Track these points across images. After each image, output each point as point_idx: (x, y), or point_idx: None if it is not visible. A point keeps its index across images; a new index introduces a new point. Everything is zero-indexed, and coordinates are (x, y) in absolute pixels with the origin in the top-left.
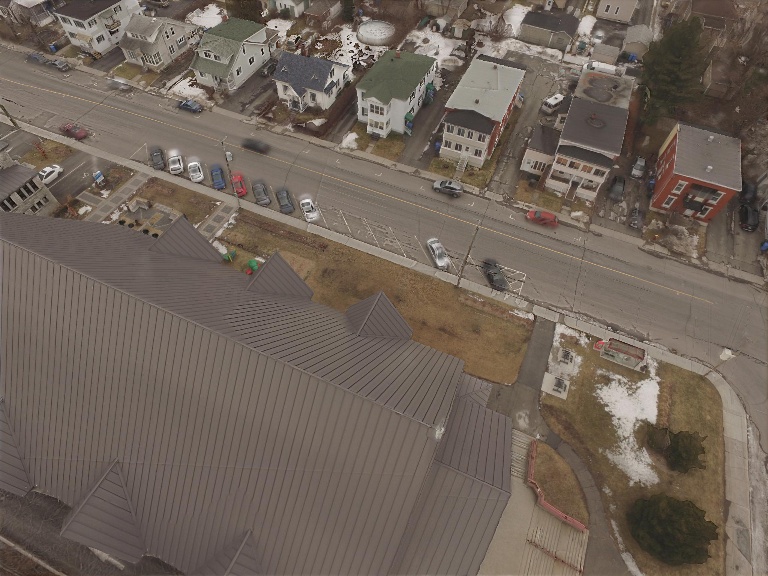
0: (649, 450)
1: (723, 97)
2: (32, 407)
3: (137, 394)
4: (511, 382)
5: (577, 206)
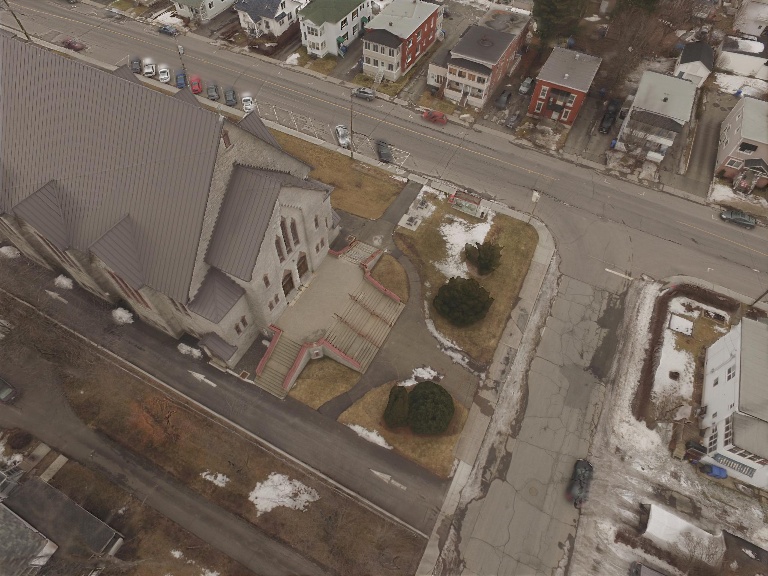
0: (468, 263)
1: (619, 39)
2: (4, 150)
3: (64, 127)
4: (376, 218)
5: (466, 111)
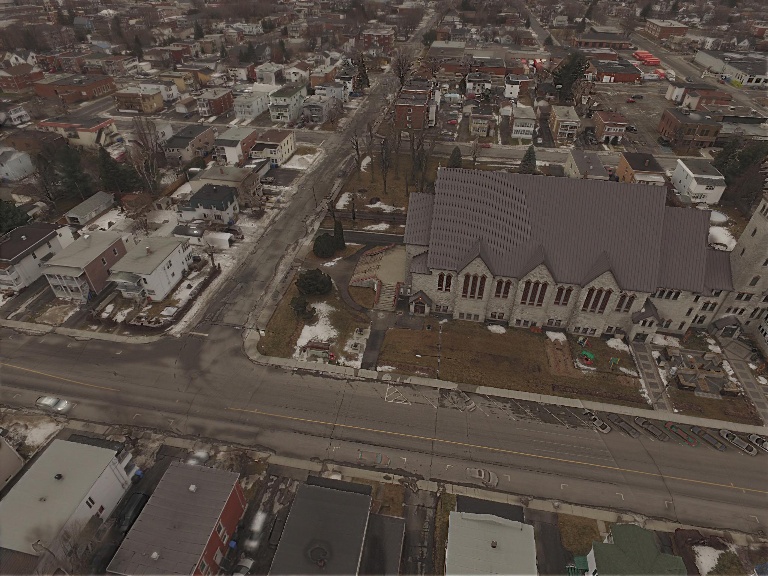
0: None
1: None
2: None
3: None
4: (389, 330)
5: None
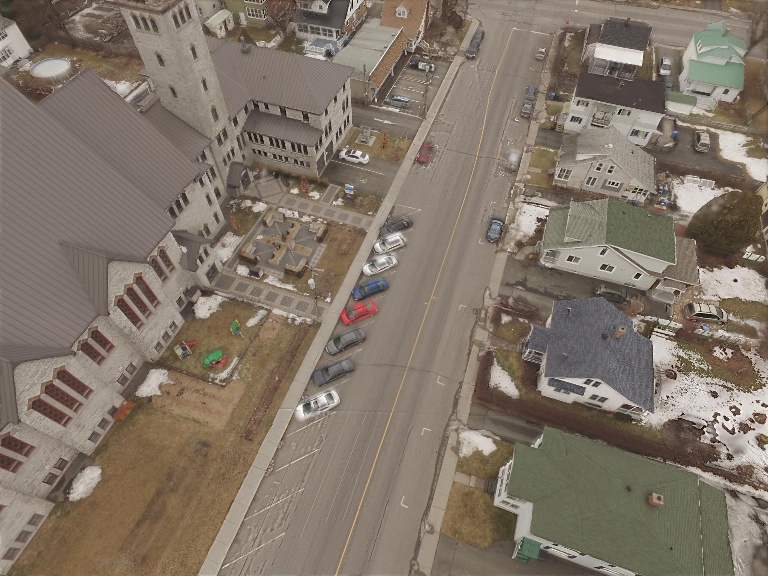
0: None
1: None
2: None
3: None
4: None
5: None
